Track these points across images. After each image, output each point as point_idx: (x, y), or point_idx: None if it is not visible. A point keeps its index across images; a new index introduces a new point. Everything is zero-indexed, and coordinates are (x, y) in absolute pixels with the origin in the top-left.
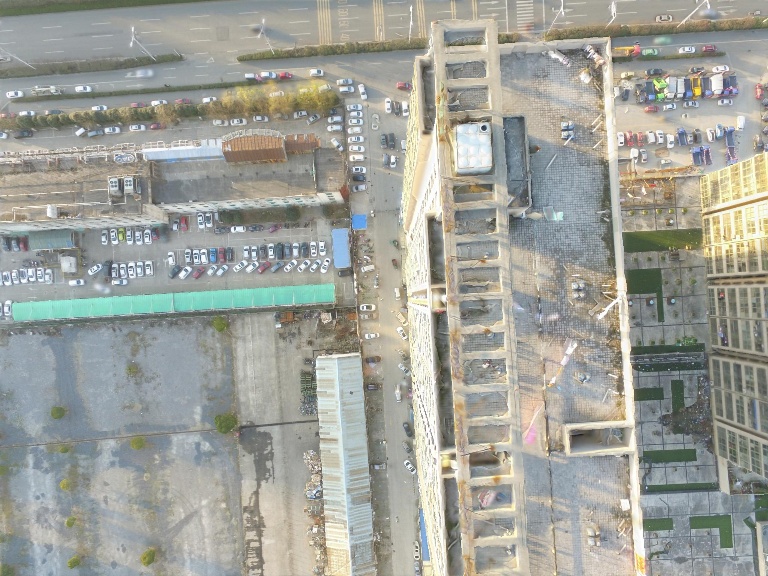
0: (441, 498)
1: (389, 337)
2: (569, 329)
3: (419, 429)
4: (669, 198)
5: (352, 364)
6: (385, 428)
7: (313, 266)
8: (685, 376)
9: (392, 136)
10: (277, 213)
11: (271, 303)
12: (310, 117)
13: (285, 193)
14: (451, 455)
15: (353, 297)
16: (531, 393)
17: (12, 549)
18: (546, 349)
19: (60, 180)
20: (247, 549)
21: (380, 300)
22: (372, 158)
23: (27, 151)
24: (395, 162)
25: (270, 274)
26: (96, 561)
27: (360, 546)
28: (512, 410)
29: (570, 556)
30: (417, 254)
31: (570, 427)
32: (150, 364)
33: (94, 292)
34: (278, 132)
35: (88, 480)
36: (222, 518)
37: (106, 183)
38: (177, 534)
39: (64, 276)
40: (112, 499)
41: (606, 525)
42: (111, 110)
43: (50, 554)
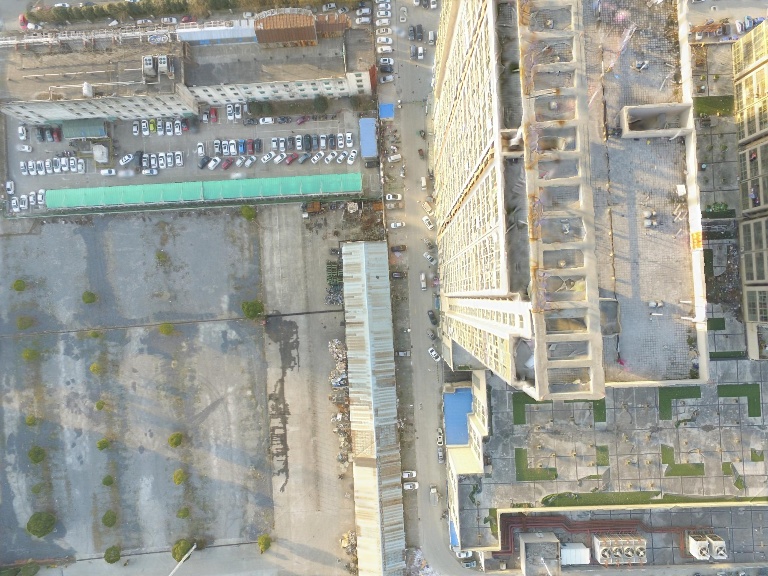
0: (501, 176)
1: (415, 227)
2: (627, 20)
3: (455, 251)
4: (701, 65)
5: (378, 249)
6: (410, 317)
7: (340, 157)
8: (714, 245)
9: (420, 27)
10: (305, 105)
11: (299, 191)
12: (339, 9)
13: (315, 76)
14: (511, 133)
15: (379, 188)
16: (589, 82)
17: (43, 433)
18: (604, 40)
19: (95, 61)
20: (272, 436)
21: (406, 190)
22: (400, 50)
23: (64, 32)
24: (423, 53)
25: (297, 166)
26: (124, 446)
27: (385, 428)
28: (577, 55)
29: (626, 239)
30: (469, 2)
31: (629, 106)
32: (179, 253)
33: (125, 182)
34: (310, 11)
35: (117, 366)
36: (248, 405)
37: (140, 63)
38: (203, 420)
39: (96, 166)
40: (140, 385)
41: (662, 210)
42: (144, 0)
43: (79, 438)
